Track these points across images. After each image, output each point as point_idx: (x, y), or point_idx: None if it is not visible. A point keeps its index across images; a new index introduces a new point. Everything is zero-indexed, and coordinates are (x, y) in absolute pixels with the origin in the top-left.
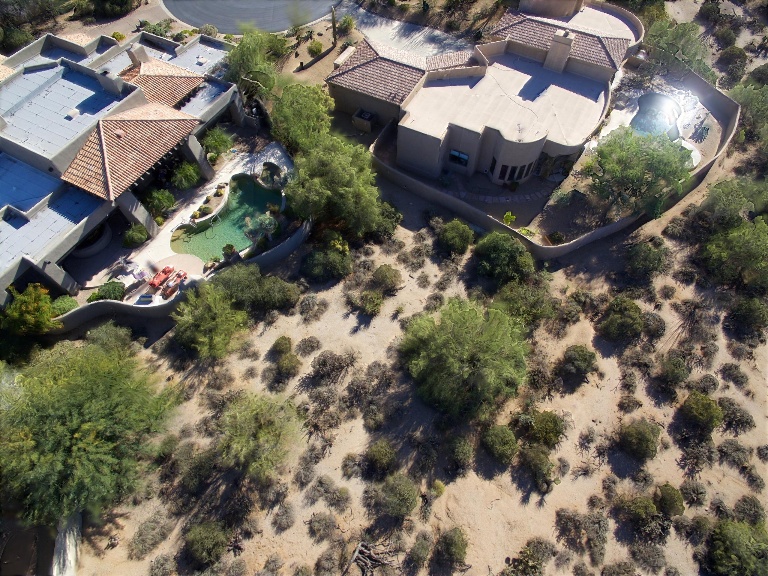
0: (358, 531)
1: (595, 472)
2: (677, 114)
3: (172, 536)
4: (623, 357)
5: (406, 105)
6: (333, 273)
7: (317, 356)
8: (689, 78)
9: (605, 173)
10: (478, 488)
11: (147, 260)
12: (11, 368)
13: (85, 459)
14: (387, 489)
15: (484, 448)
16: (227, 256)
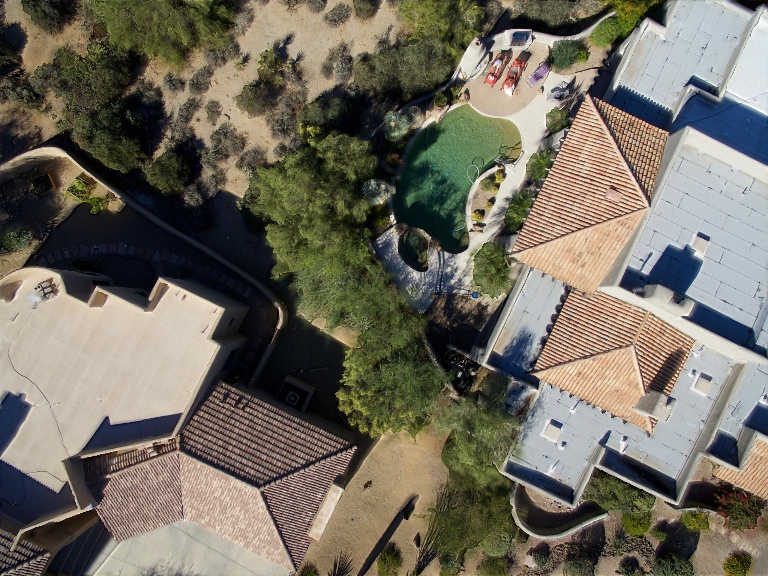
0: None
1: None
2: None
3: None
4: None
5: None
6: None
7: None
8: None
9: None
10: None
11: (541, 108)
12: None
13: None
14: None
15: None
16: None
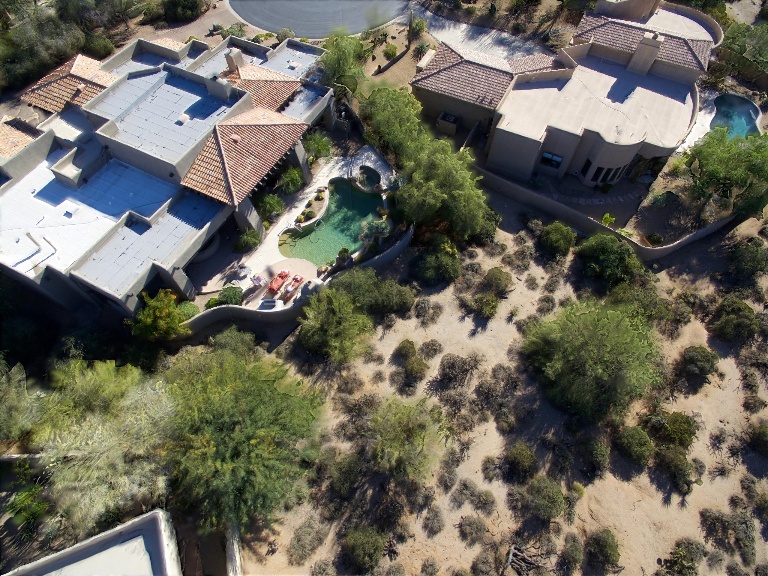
0: (507, 534)
1: (731, 472)
2: (754, 115)
3: (327, 541)
4: (741, 357)
5: (500, 108)
6: (444, 276)
7: (442, 359)
8: (762, 79)
9: (705, 174)
10: (618, 490)
11: (259, 265)
12: (143, 374)
13: (261, 465)
14: (533, 492)
15: (617, 450)
16: (341, 260)
